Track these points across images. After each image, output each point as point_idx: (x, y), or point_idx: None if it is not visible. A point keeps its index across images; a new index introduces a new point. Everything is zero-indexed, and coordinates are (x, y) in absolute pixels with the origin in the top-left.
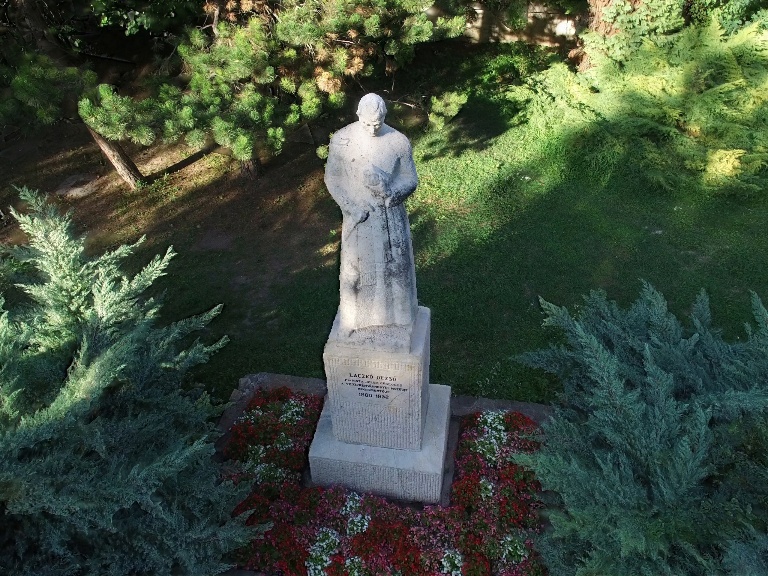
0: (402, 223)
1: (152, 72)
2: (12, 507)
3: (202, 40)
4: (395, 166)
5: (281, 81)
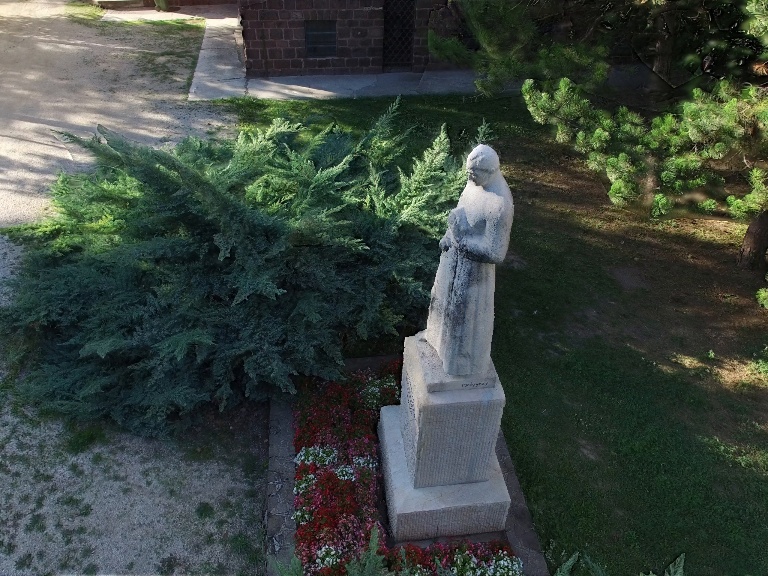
0: (467, 278)
1: (677, 103)
2: (218, 236)
3: (727, 95)
4: (479, 223)
5: (752, 170)
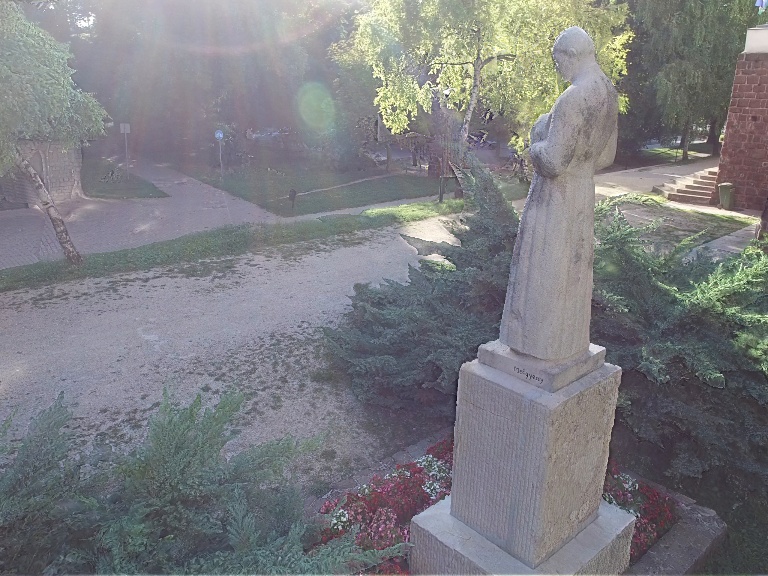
0: None
1: None
2: None
3: None
4: None
5: None
